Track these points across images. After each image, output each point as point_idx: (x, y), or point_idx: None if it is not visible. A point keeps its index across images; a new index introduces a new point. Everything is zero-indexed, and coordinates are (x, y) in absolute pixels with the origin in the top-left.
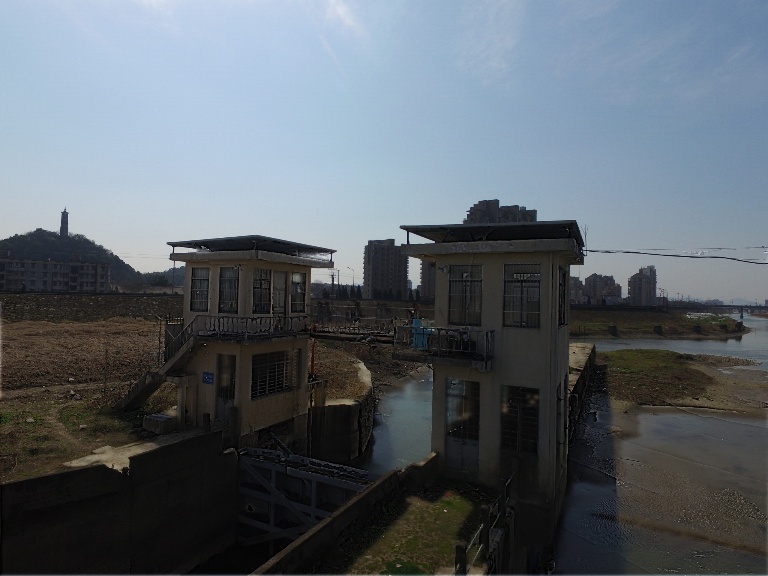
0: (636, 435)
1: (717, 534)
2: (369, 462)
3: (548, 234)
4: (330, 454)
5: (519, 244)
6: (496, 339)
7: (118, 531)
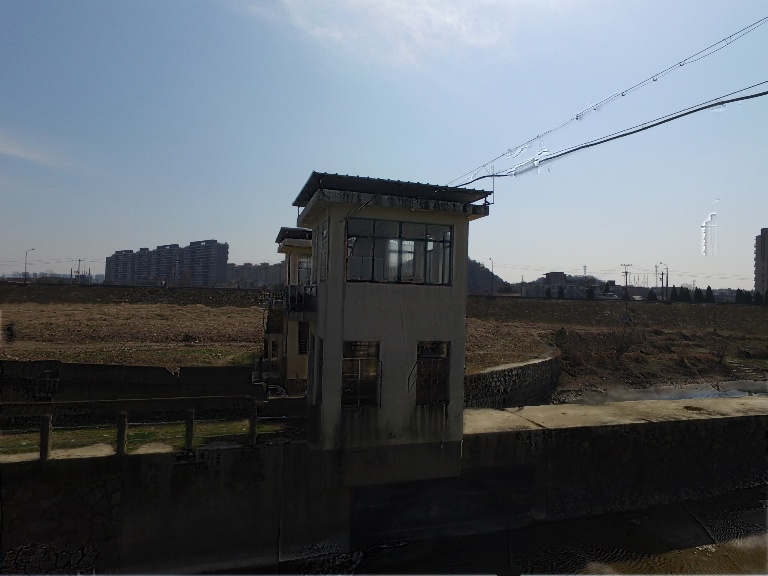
0: None
1: None
2: None
3: (339, 188)
4: None
5: (310, 203)
6: (318, 294)
7: None
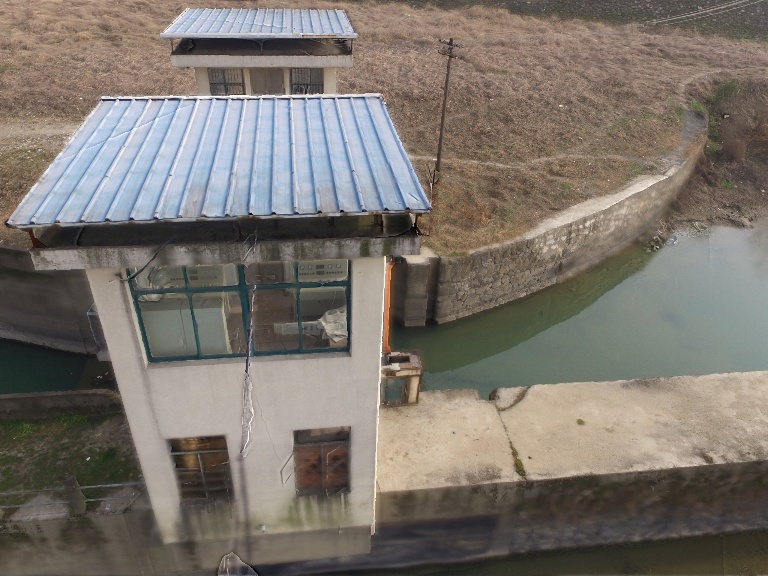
0: None
1: None
2: (491, 335)
3: None
4: (390, 307)
5: None
6: None
7: (63, 303)
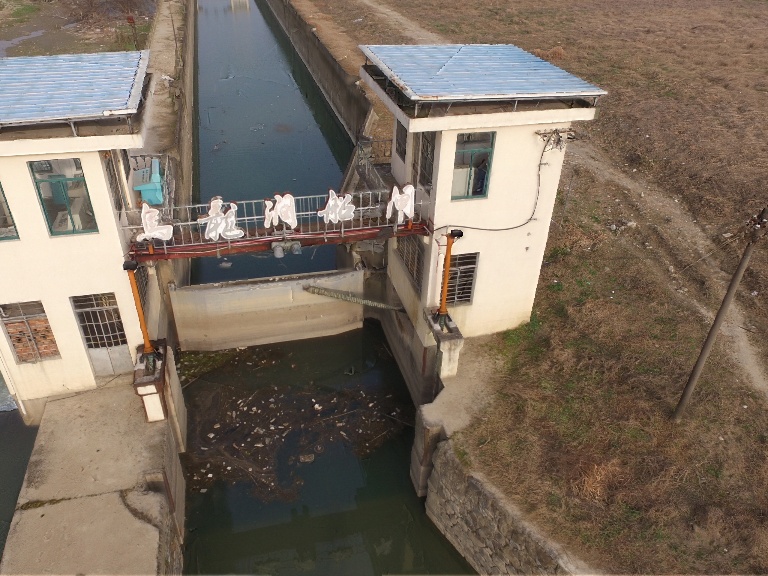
0: None
1: None
2: None
3: None
4: None
5: None
6: None
7: None
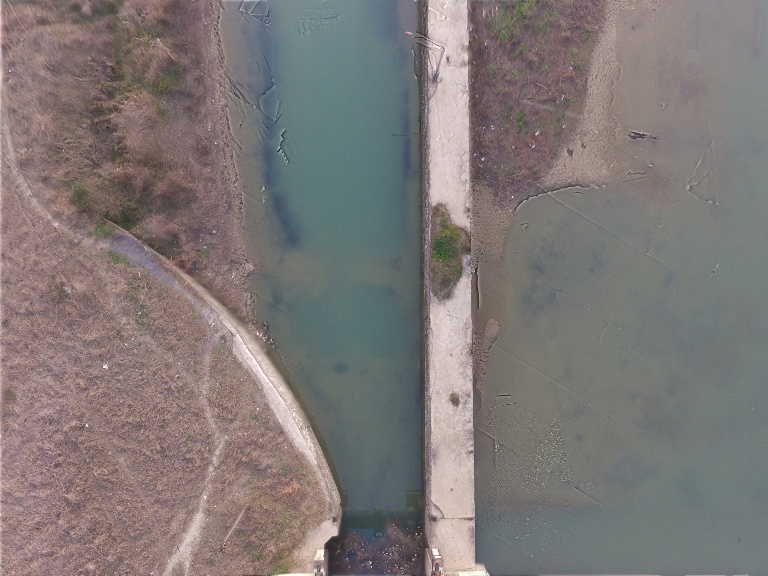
0: (509, 327)
1: (539, 493)
2: None
3: None
4: None
5: None
6: None
7: None
